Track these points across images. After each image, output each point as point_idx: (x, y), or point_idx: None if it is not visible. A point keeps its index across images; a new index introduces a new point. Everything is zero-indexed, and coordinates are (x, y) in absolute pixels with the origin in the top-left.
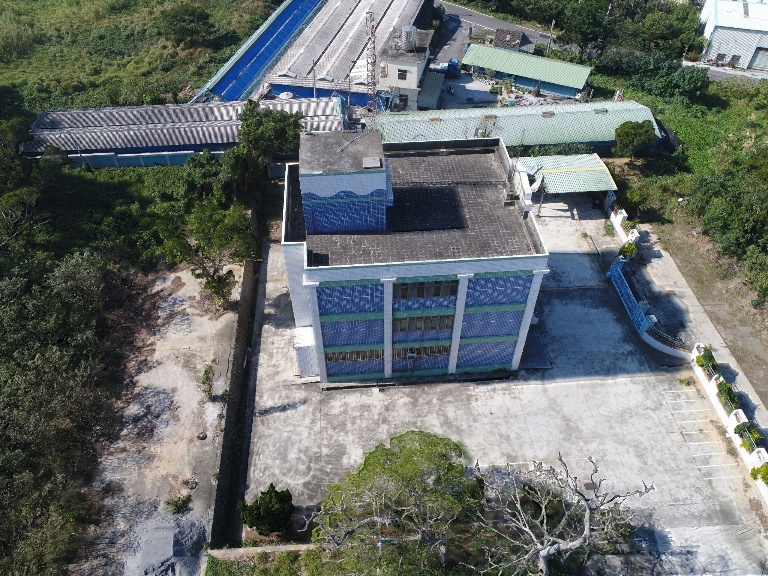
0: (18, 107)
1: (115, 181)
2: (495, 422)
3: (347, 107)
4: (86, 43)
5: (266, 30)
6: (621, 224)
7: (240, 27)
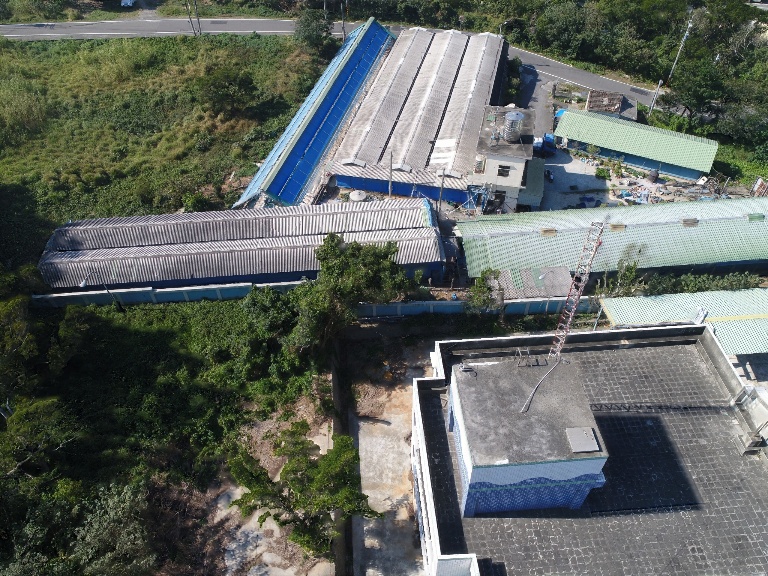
0: (30, 213)
1: (154, 328)
2: None
3: (434, 210)
4: (108, 114)
5: (323, 101)
6: None
7: (287, 90)
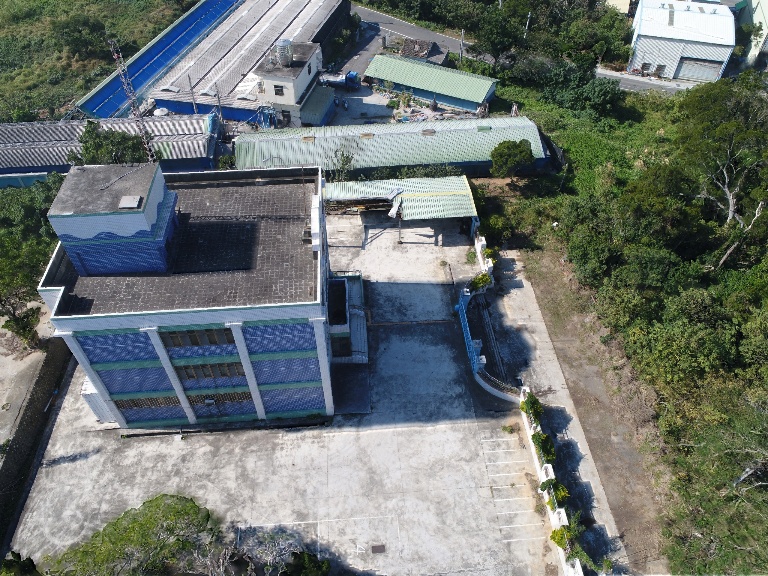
0: None
1: None
2: (295, 475)
3: None
4: None
5: (158, 41)
6: (481, 252)
7: (141, 37)
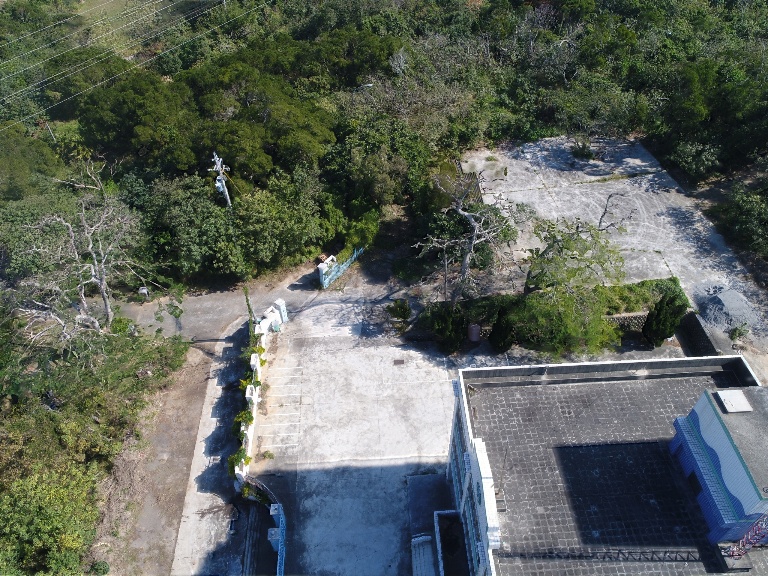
0: None
1: None
2: None
3: None
4: None
5: None
6: None
7: None
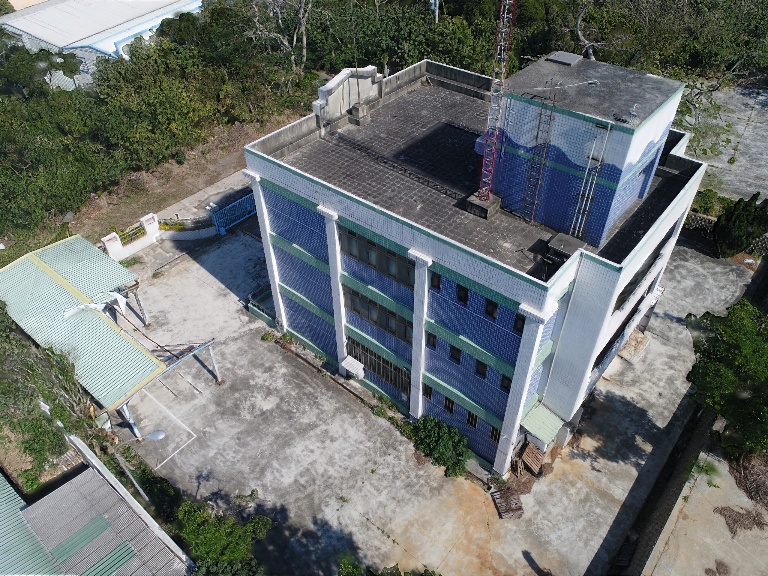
0: None
1: None
2: None
3: None
4: None
5: None
6: (122, 245)
7: None
